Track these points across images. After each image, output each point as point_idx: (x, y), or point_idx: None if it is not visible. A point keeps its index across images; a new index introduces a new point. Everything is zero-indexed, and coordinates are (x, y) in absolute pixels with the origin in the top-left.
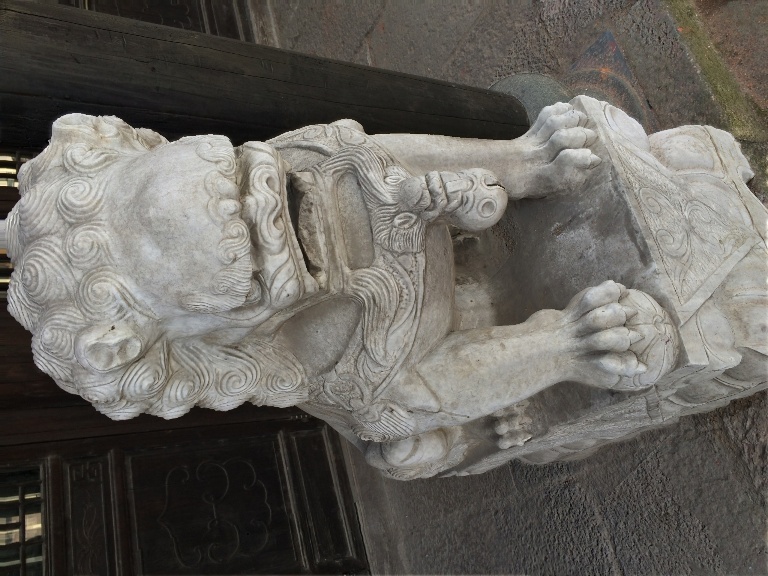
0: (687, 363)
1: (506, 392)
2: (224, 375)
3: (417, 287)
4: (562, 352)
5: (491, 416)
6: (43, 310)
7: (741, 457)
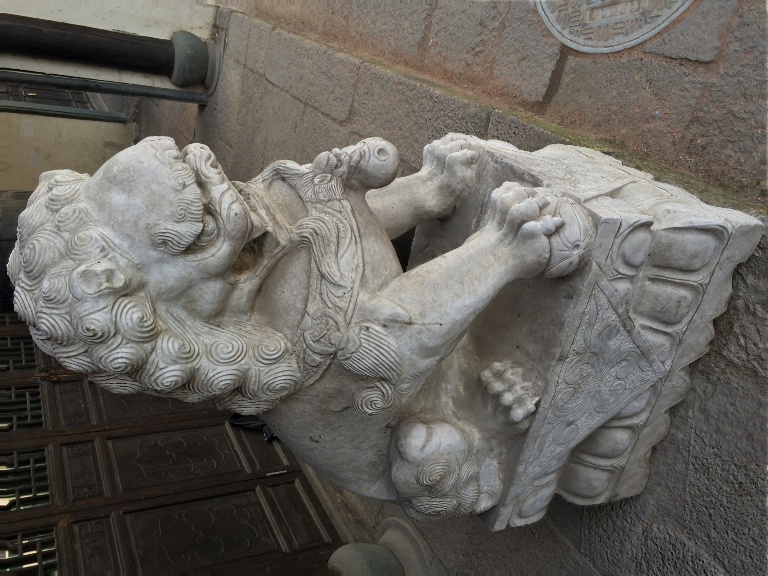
0: (601, 219)
1: (463, 292)
2: (212, 345)
3: (350, 221)
4: (494, 245)
5: (493, 394)
6: (42, 279)
7: (757, 375)
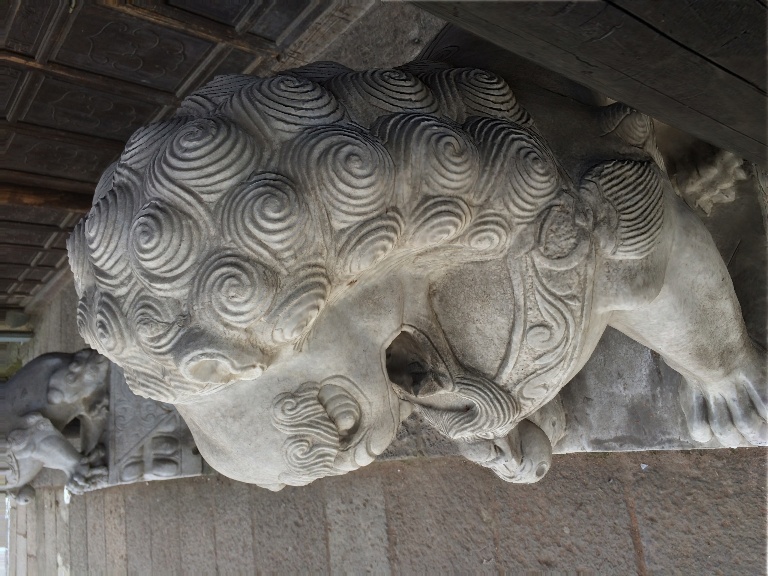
0: None
1: None
2: None
3: None
4: None
5: None
6: None
7: None
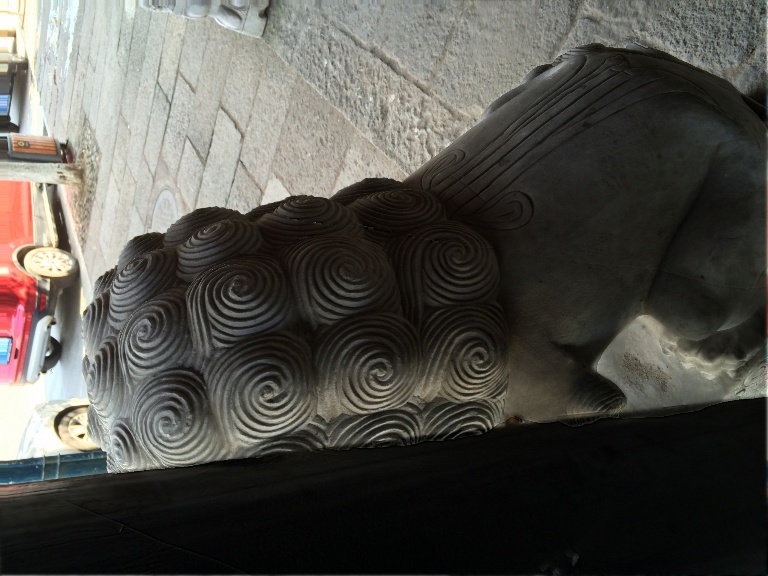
0: None
1: None
2: None
3: None
4: None
5: None
6: None
7: None
